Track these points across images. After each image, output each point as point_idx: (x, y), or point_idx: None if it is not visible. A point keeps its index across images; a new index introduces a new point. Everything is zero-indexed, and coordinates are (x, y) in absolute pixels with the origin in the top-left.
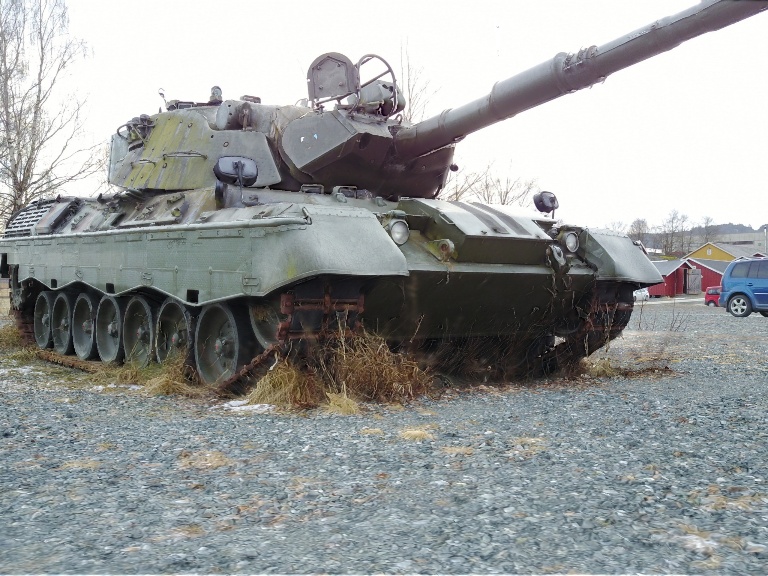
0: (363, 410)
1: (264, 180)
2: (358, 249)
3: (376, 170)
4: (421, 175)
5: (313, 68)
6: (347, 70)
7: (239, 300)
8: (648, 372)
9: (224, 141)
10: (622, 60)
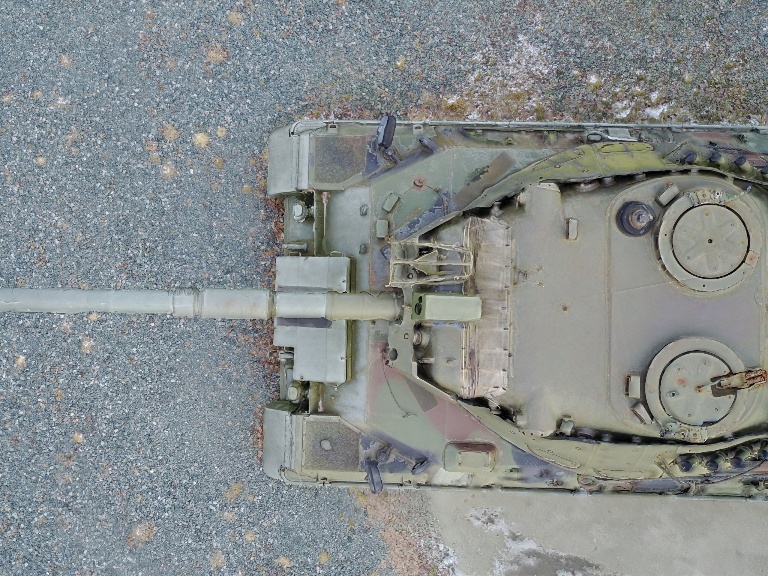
0: None
1: None
2: None
3: None
4: None
5: (420, 208)
6: None
7: None
8: None
9: None
10: None
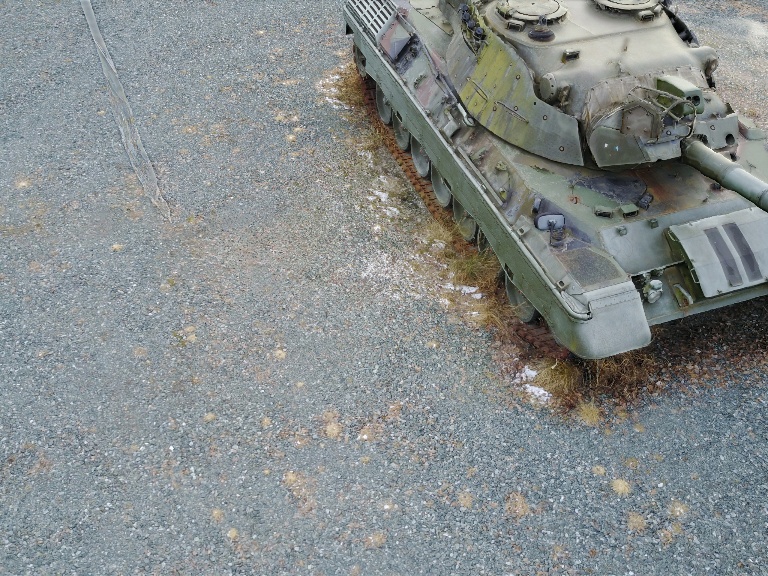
0: (601, 415)
1: (571, 161)
2: (619, 332)
3: None
4: None
5: (625, 111)
6: (653, 121)
7: None
8: None
9: (544, 114)
10: None
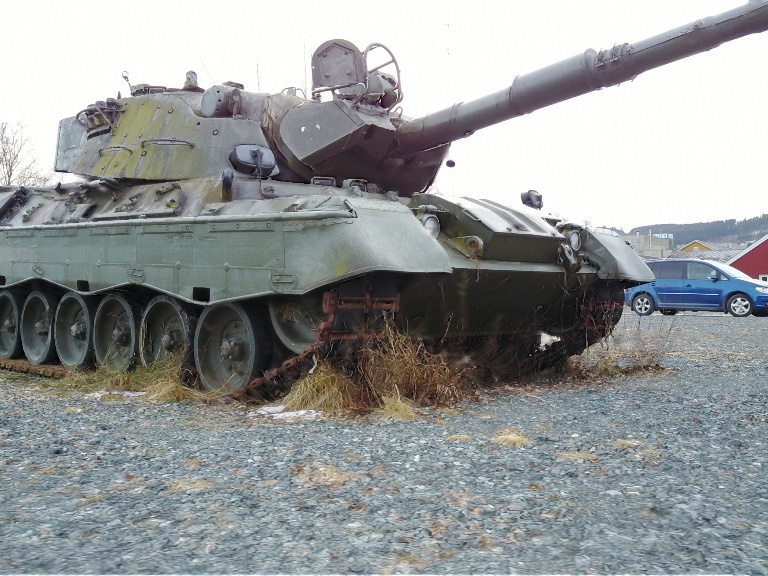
0: (418, 414)
1: None
2: (403, 245)
3: (376, 164)
4: (416, 170)
5: (318, 55)
6: (355, 58)
7: (264, 299)
8: (643, 370)
9: (213, 129)
10: (660, 58)
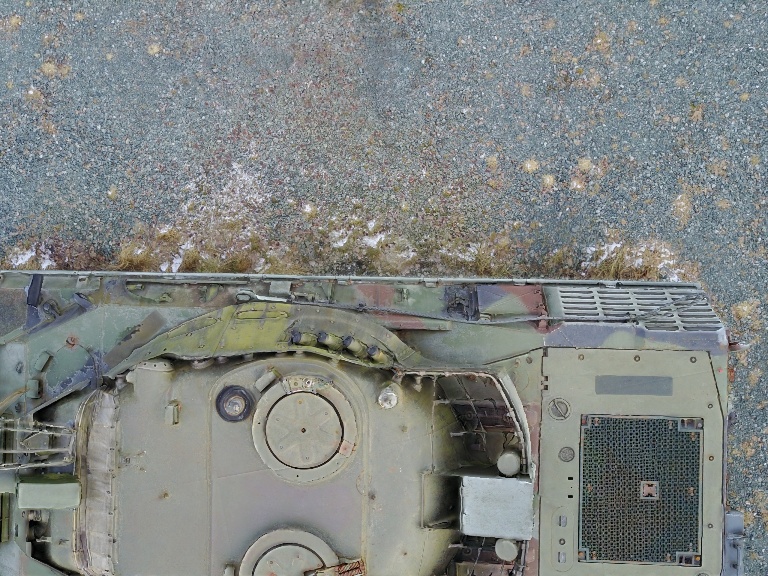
0: None
1: None
2: None
3: None
4: None
5: (16, 392)
6: None
7: None
8: None
9: None
10: None
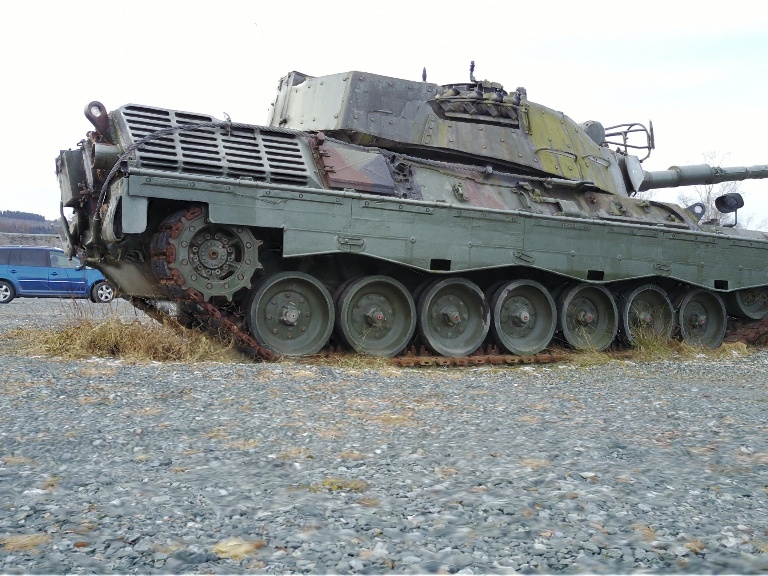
0: None
1: None
2: None
3: None
4: None
5: None
6: None
7: None
8: None
9: None
10: (731, 178)
